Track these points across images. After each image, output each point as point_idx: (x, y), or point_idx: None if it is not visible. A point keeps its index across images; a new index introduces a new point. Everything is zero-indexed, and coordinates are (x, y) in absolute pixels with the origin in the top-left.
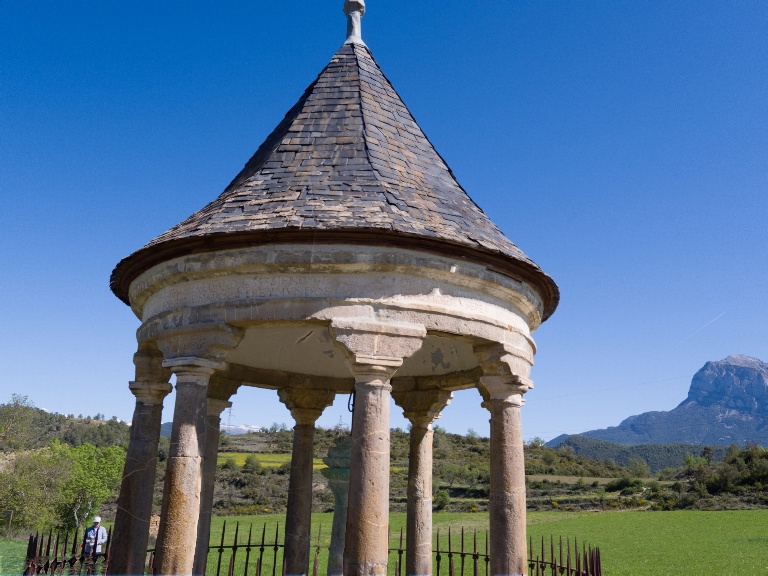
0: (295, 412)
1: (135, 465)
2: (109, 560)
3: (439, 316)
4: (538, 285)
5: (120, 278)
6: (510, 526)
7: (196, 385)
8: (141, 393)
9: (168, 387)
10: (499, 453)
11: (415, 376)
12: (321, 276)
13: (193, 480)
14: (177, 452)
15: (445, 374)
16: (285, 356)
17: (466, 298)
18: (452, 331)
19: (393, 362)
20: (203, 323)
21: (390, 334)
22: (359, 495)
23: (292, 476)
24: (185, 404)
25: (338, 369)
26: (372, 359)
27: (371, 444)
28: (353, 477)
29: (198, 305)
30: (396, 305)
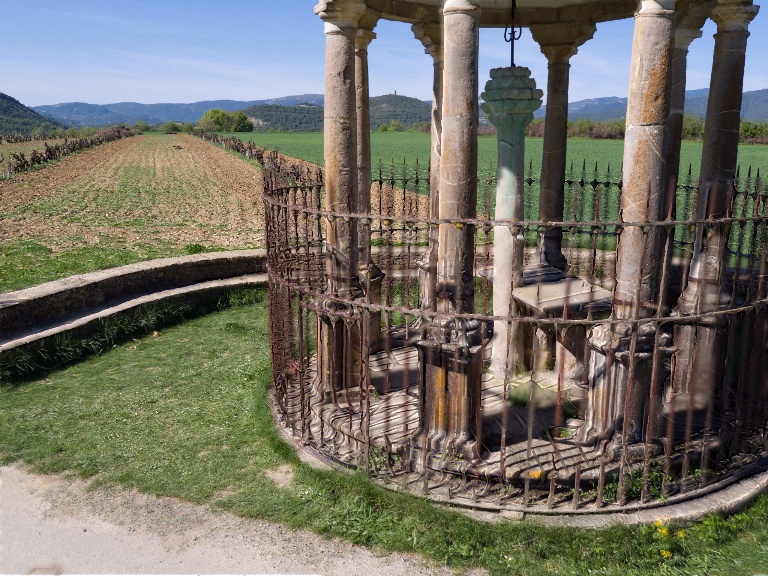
0: None
1: None
2: None
3: None
4: None
5: None
6: None
7: None
8: None
9: None
10: None
11: None
12: None
13: None
14: None
15: None
16: None
17: None
18: None
19: None
20: None
21: None
22: None
23: None
24: None
25: None
26: None
27: None
28: None
29: None
30: None
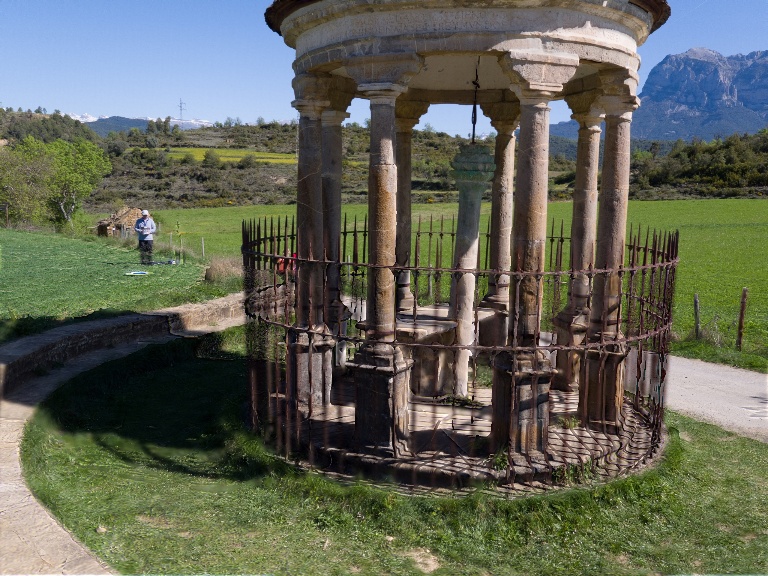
0: (397, 121)
1: (309, 170)
2: (298, 242)
3: (590, 47)
4: (657, 13)
5: (284, 3)
6: (616, 214)
7: (390, 106)
8: (307, 109)
9: None
10: (612, 159)
11: (503, 89)
12: (499, 11)
13: (394, 182)
14: (380, 161)
15: None
16: None
17: (608, 29)
18: (597, 59)
19: (556, 88)
20: (395, 53)
21: (554, 64)
22: (528, 192)
23: None
24: (383, 122)
25: (431, 82)
26: (541, 86)
27: (537, 154)
28: (522, 179)
29: (387, 36)
30: (560, 38)
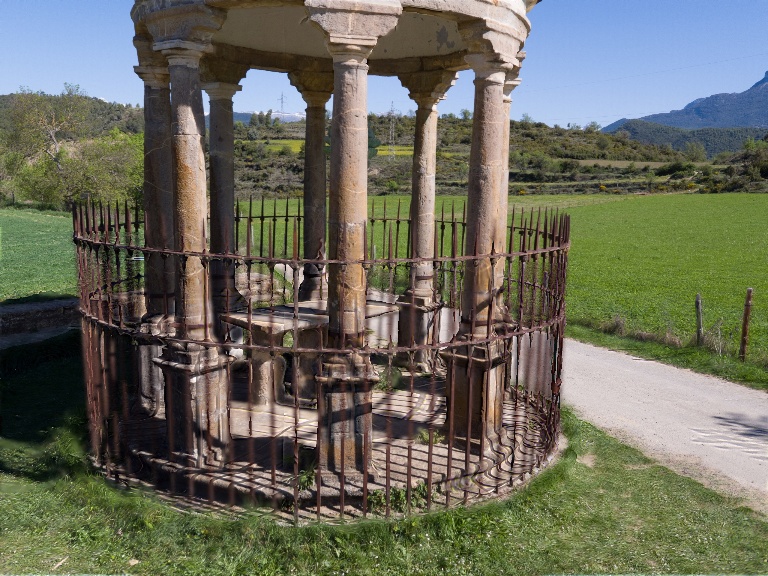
0: (305, 95)
1: (153, 144)
2: None
3: None
4: None
5: None
6: (483, 195)
7: (186, 68)
8: (147, 77)
9: None
10: (478, 130)
11: (420, 57)
12: None
13: (195, 155)
14: (178, 130)
15: (449, 54)
16: (291, 38)
17: None
18: (430, 7)
19: (367, 41)
20: (184, 5)
21: (364, 12)
22: (338, 167)
23: (306, 155)
24: (179, 86)
25: None
26: (346, 38)
27: (348, 121)
28: (333, 151)
29: None
30: None
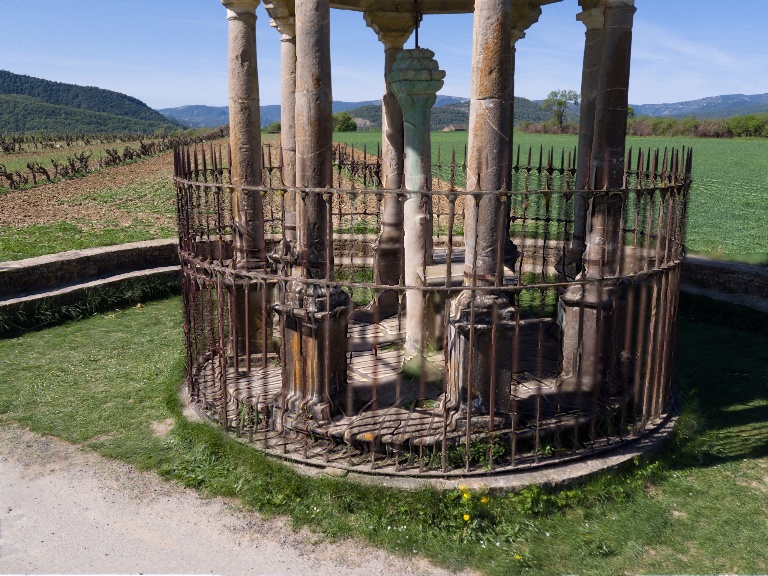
0: None
1: None
2: None
3: None
4: None
5: None
6: None
7: None
8: None
9: None
10: None
11: None
12: None
13: None
14: None
15: None
16: None
17: None
18: None
19: None
20: None
21: None
22: None
23: None
24: None
25: None
26: None
27: None
28: None
29: None
30: None
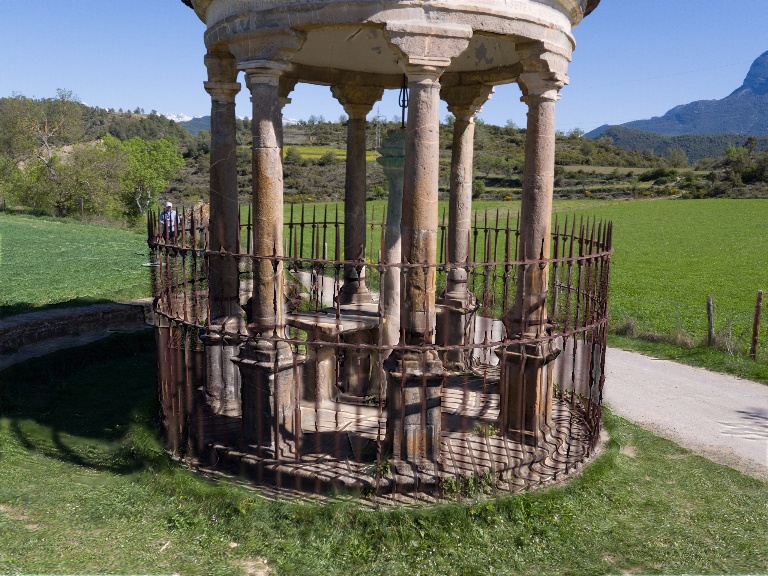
0: (348, 107)
1: (219, 155)
2: (210, 231)
3: (485, 16)
4: None
5: None
6: (537, 203)
7: (269, 86)
8: (215, 92)
9: (238, 87)
10: (533, 143)
11: (459, 71)
12: None
13: (275, 167)
14: (260, 144)
15: (488, 69)
16: (336, 54)
17: None
18: (496, 31)
19: (442, 62)
20: (269, 28)
21: (439, 36)
22: (413, 177)
23: (348, 165)
24: (261, 103)
25: (386, 65)
26: (423, 60)
27: (423, 136)
28: (408, 163)
29: (262, 10)
30: (445, 7)
